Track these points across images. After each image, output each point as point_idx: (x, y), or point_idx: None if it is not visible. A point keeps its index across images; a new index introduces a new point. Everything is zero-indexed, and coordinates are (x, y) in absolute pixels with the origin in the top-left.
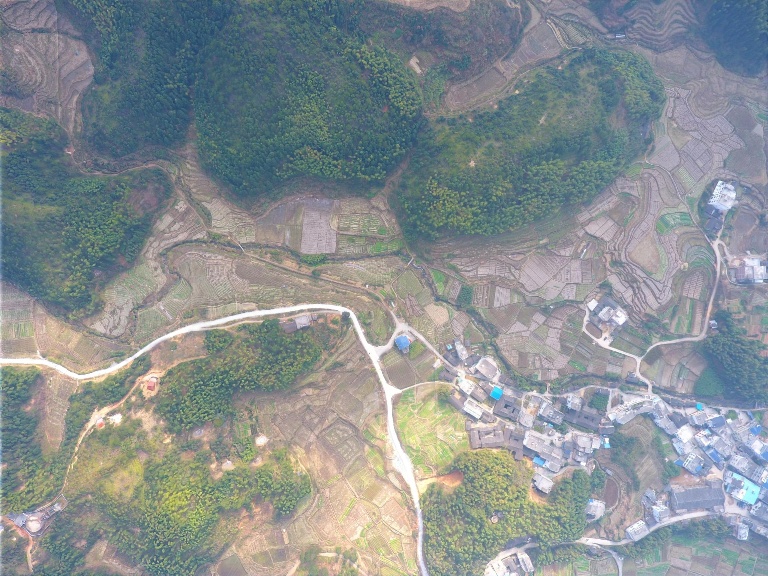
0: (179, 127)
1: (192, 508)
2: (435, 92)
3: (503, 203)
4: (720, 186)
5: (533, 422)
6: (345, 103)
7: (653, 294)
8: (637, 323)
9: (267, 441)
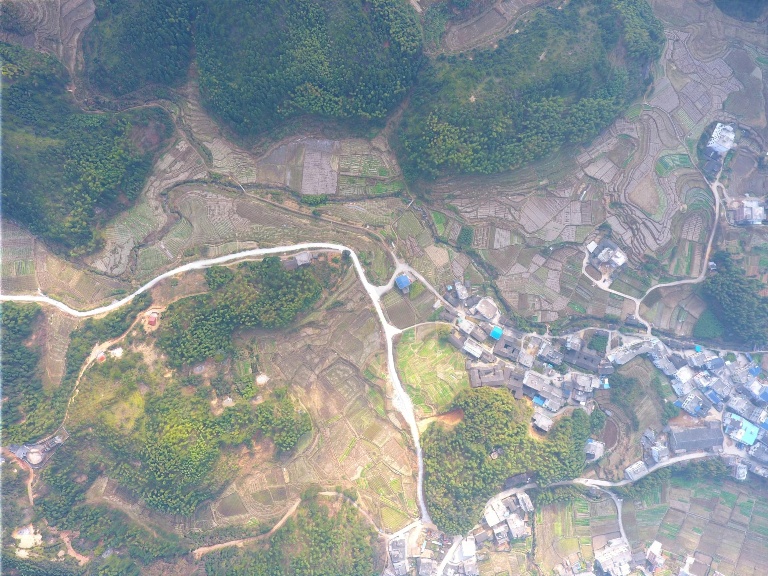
0: (180, 64)
1: (193, 442)
2: (435, 31)
3: (503, 140)
4: (719, 128)
5: (533, 362)
6: (346, 36)
7: (652, 235)
8: (636, 265)
9: (268, 380)
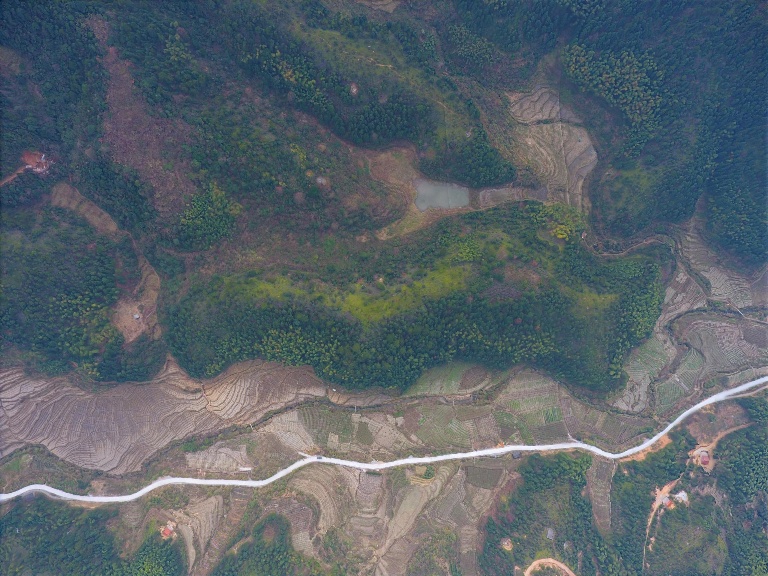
0: None
1: None
2: None
3: None
4: None
5: None
6: None
7: None
8: None
9: None
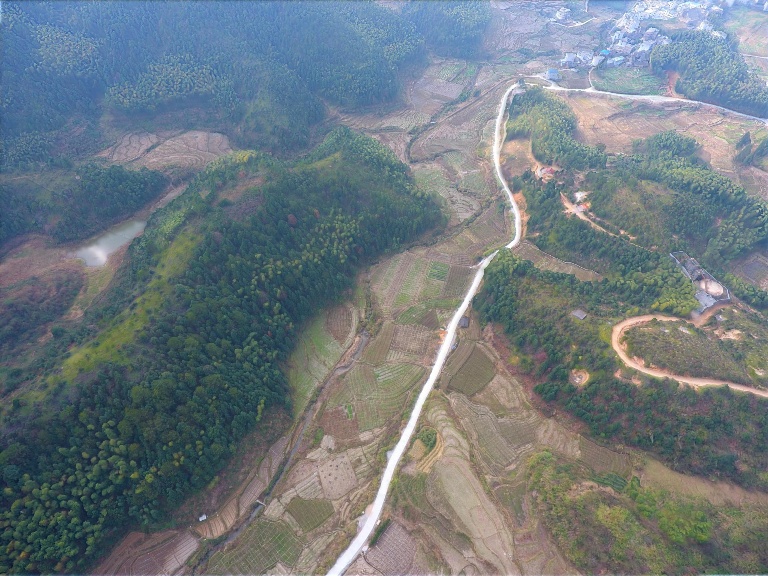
0: None
1: None
2: None
3: None
4: None
5: None
6: None
7: (555, 0)
8: None
9: (623, 153)
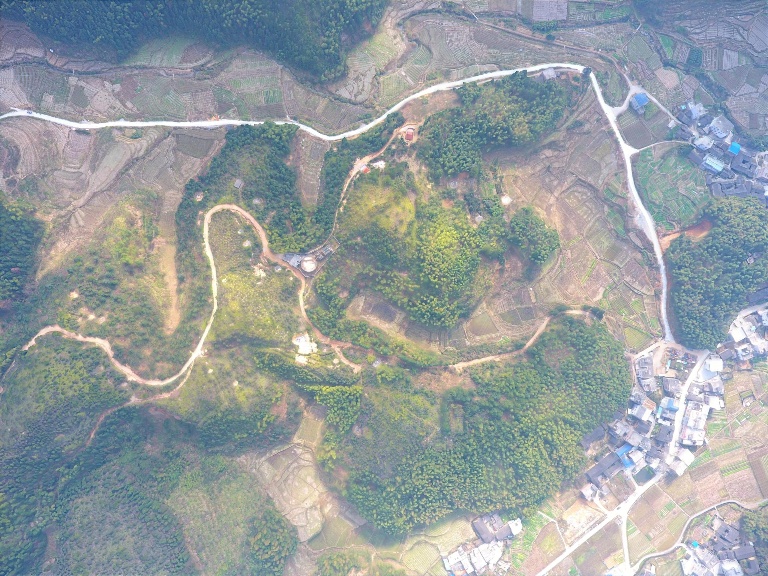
0: None
1: None
2: None
3: None
4: None
5: None
6: None
7: None
8: None
9: (511, 201)
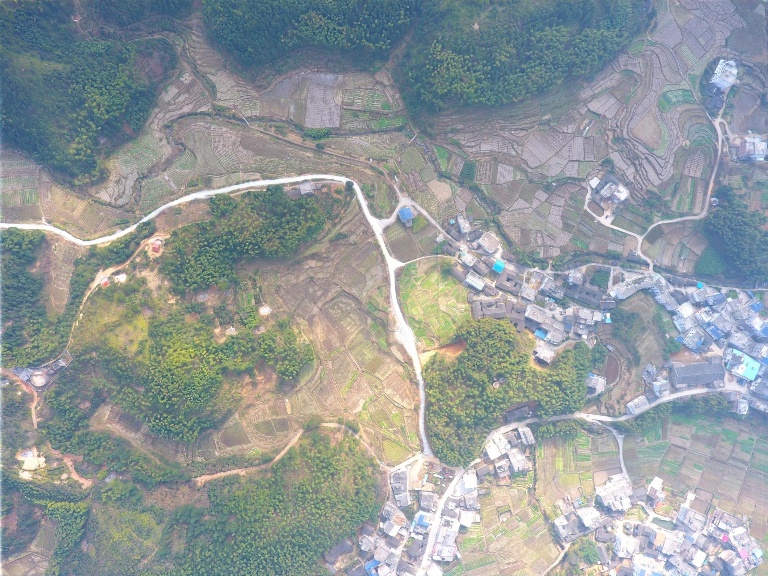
0: None
1: (196, 368)
2: None
3: (506, 70)
4: (722, 64)
5: (535, 296)
6: None
7: (655, 170)
8: (639, 201)
9: (270, 311)
